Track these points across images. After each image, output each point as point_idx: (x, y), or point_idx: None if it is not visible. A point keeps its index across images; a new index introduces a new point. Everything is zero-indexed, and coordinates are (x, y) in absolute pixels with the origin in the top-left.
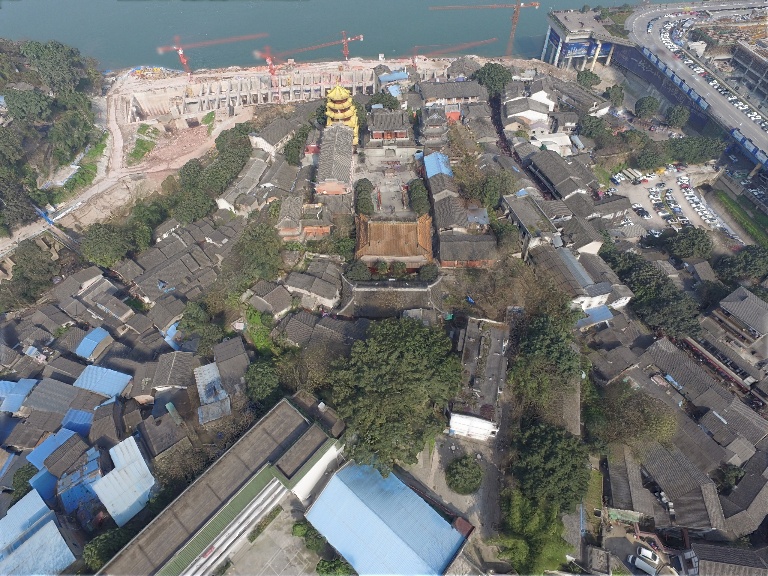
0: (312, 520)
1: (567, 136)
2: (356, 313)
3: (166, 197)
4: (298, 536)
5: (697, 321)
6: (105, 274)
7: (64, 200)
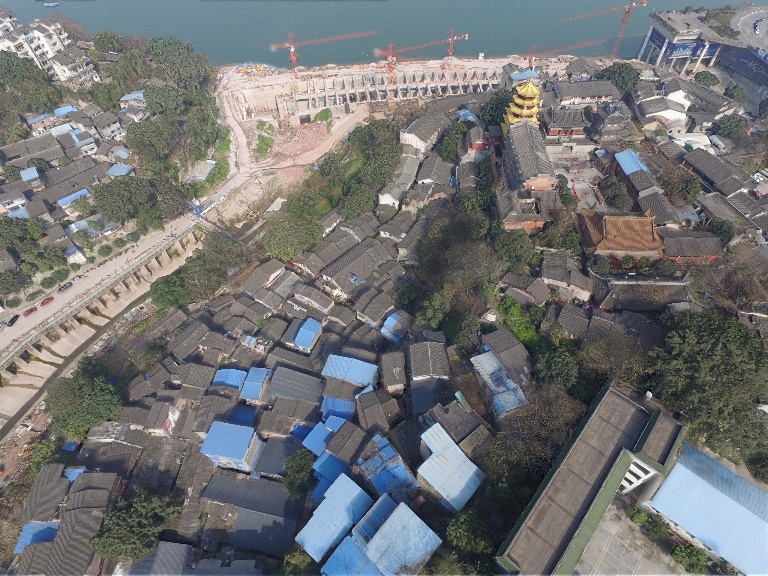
0: (658, 506)
1: (705, 136)
2: (615, 306)
3: (318, 192)
4: None
5: None
6: (287, 267)
7: (206, 194)
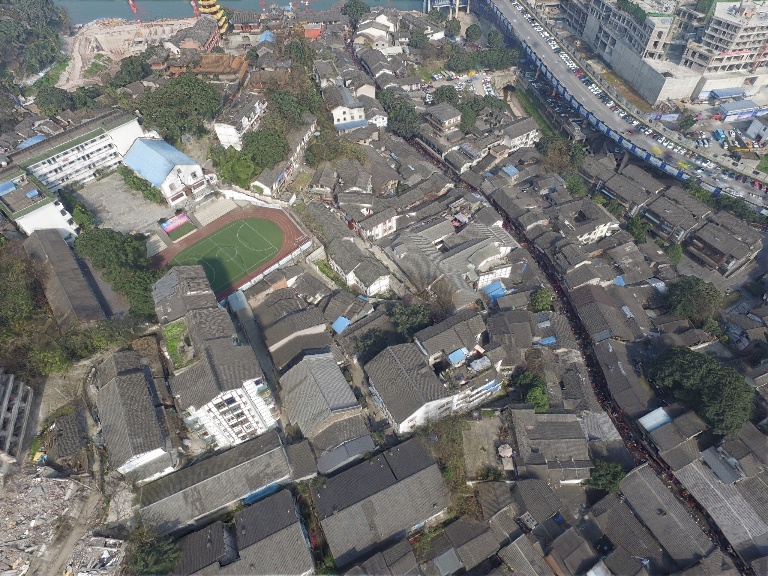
0: (125, 161)
1: (400, 47)
2: None
3: None
4: (121, 174)
5: (418, 124)
6: (51, 119)
7: (33, 95)
